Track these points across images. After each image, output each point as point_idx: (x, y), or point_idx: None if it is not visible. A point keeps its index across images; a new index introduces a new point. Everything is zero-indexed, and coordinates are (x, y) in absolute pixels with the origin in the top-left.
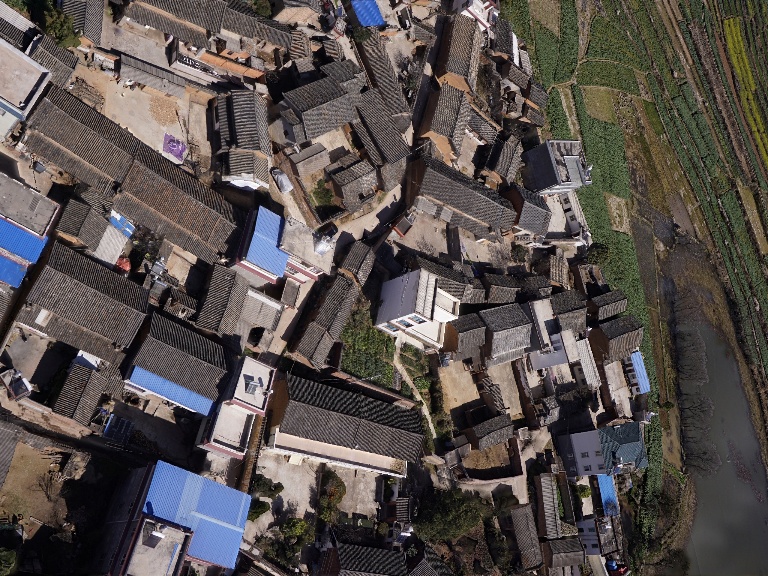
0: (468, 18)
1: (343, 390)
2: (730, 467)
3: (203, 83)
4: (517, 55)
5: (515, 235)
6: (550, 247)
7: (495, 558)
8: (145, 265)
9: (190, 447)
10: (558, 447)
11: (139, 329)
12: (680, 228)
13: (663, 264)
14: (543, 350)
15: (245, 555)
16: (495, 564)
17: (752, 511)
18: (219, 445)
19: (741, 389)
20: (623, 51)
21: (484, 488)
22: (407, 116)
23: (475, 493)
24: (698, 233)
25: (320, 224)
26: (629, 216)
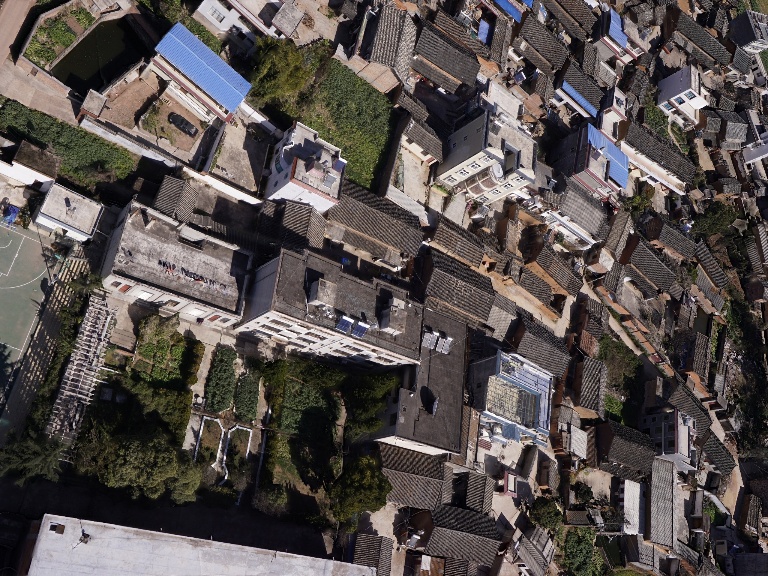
0: None
1: None
2: None
3: None
4: None
5: (726, 75)
6: (748, 88)
7: (735, 265)
8: None
9: None
10: (763, 217)
11: None
12: None
13: None
14: (756, 142)
15: (609, 210)
16: None
17: None
18: None
19: None
20: None
21: None
22: None
23: None
24: None
25: None
26: None
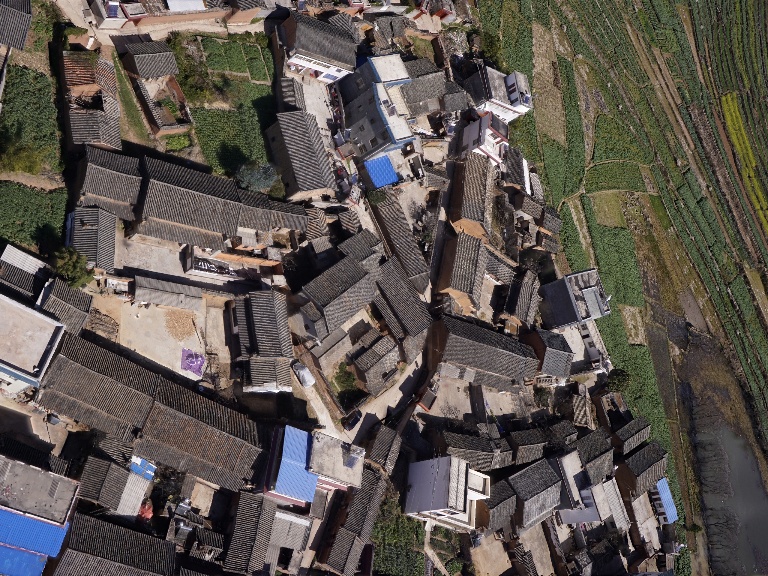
0: (480, 155)
1: None
2: None
3: (219, 283)
4: (528, 180)
5: (537, 377)
6: (572, 383)
7: None
8: (168, 508)
9: None
10: None
11: None
12: (693, 326)
13: (679, 369)
14: (574, 509)
15: None
16: None
17: None
18: None
19: (762, 488)
20: (627, 147)
21: None
22: (425, 274)
23: None
24: (710, 327)
25: (344, 416)
26: (644, 325)
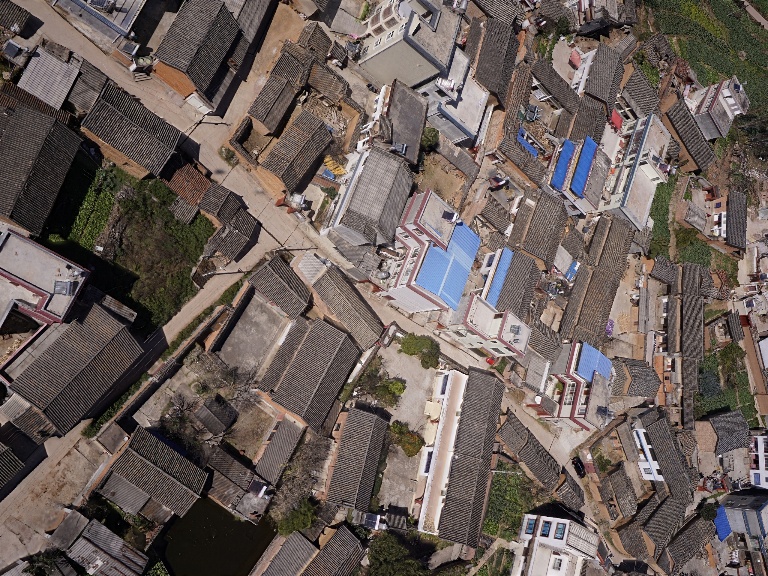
0: None
1: None
2: None
3: None
4: None
5: None
6: None
7: None
8: None
9: None
10: None
11: None
12: None
13: None
14: None
15: None
16: None
17: None
18: (475, 301)
19: None
20: None
21: None
22: (670, 570)
23: None
24: None
25: (590, 449)
26: None
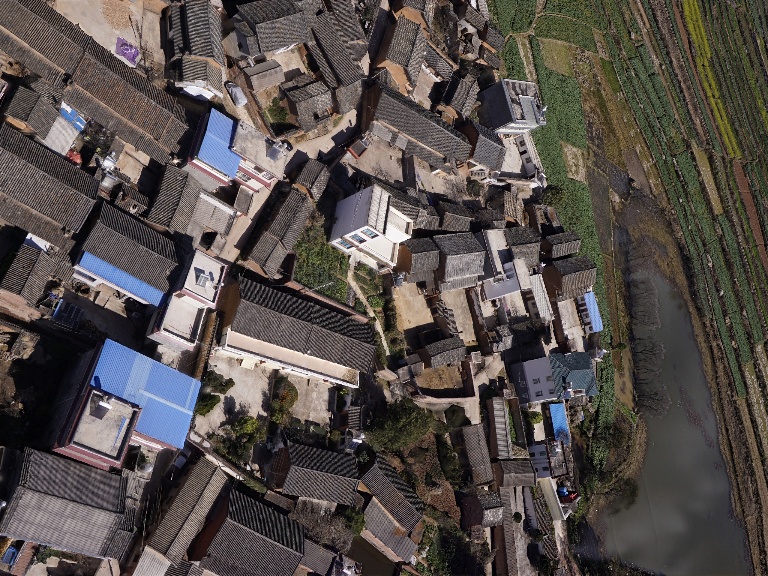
0: None
1: (296, 298)
2: (681, 412)
3: None
4: None
5: (470, 170)
6: (505, 185)
7: (447, 473)
8: (96, 159)
9: (141, 341)
10: (511, 375)
11: (89, 217)
12: (635, 183)
13: (618, 215)
14: (496, 277)
15: (196, 449)
16: (447, 479)
17: (702, 455)
18: (169, 334)
19: (693, 340)
20: (581, 9)
21: (437, 407)
22: (363, 44)
23: (428, 411)
24: (653, 189)
25: (274, 138)
26: (585, 166)
